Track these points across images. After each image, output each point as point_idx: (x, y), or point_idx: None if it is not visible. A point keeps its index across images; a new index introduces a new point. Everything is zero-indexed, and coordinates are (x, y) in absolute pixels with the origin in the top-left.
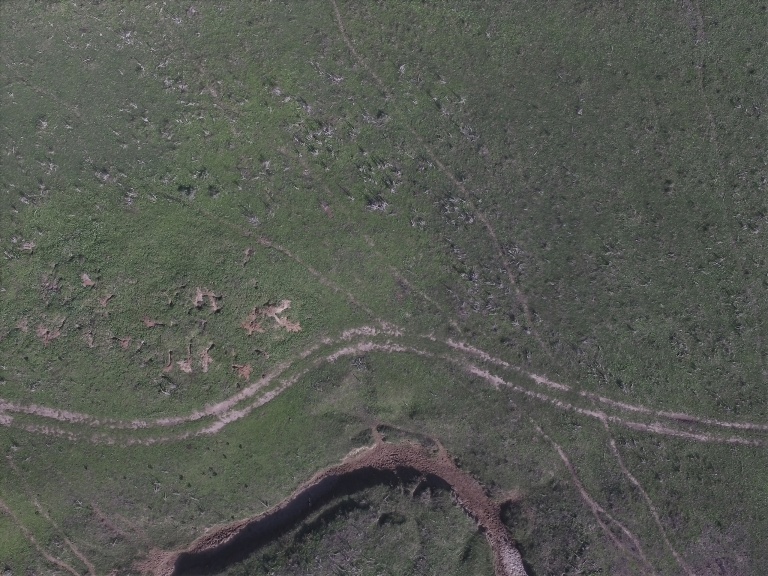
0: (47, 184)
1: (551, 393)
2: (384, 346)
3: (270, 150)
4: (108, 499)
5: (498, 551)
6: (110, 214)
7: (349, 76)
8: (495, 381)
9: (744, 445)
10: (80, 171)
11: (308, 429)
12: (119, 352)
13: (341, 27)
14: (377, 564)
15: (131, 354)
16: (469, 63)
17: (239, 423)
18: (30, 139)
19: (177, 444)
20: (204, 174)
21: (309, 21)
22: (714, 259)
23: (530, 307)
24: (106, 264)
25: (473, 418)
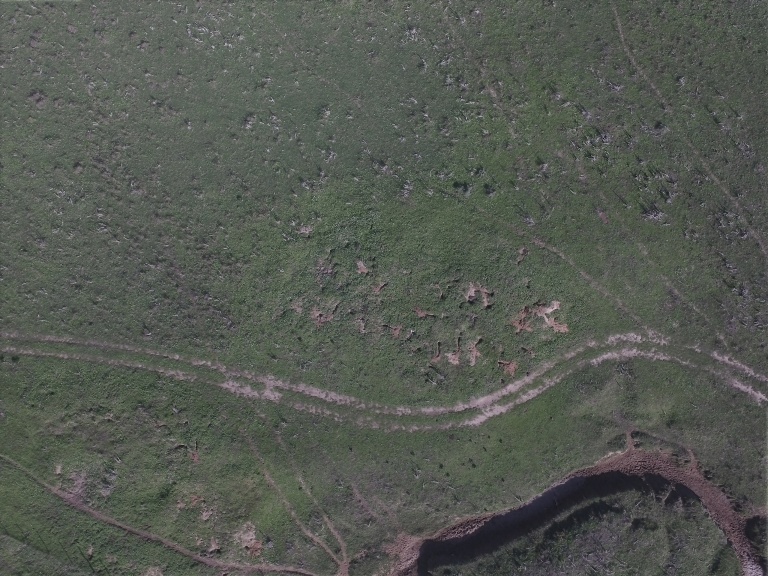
0: (326, 171)
1: None
2: (648, 354)
3: (547, 153)
4: (368, 481)
5: (740, 566)
6: (386, 204)
7: (628, 85)
8: (757, 397)
9: None
10: (358, 161)
11: (568, 429)
12: (390, 339)
13: (621, 36)
14: (629, 568)
15: (401, 342)
16: (748, 80)
17: (501, 418)
18: (312, 126)
19: (440, 433)
20: (481, 172)
21: (590, 28)
22: None
23: None
24: (381, 253)
25: (731, 432)
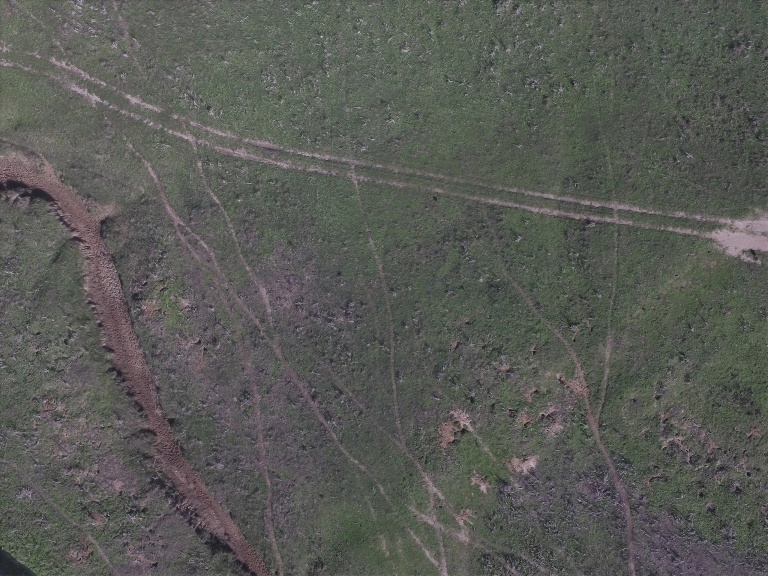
0: None
1: (144, 113)
2: None
3: None
4: None
5: (97, 265)
6: None
7: None
8: (93, 99)
9: (322, 175)
10: None
11: None
12: None
13: None
14: None
15: None
16: None
17: None
18: None
19: None
20: None
21: None
22: (309, 3)
23: (131, 33)
24: None
25: (72, 133)
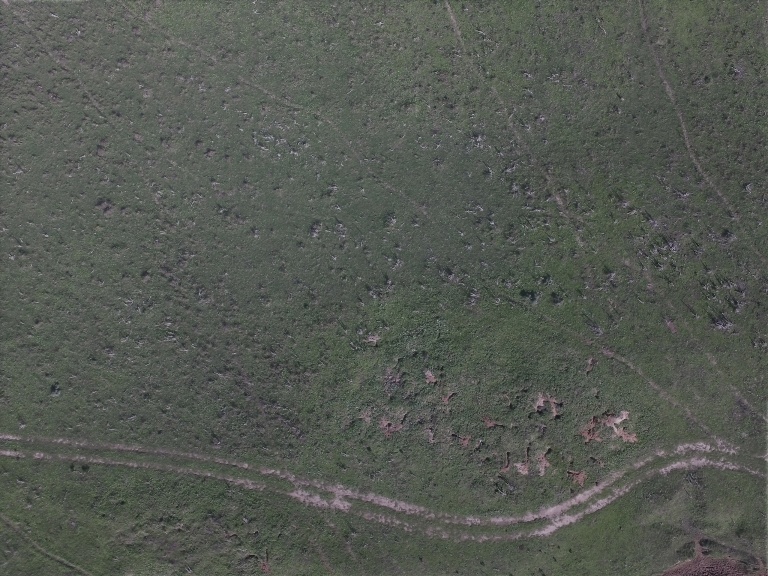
0: (392, 279)
1: None
2: (717, 463)
3: (614, 261)
4: None
5: None
6: (453, 313)
7: (694, 192)
8: None
9: None
10: (424, 268)
11: (637, 539)
12: (459, 450)
13: (687, 143)
14: None
15: (470, 452)
16: None
17: (571, 528)
18: (378, 234)
19: (510, 544)
20: (548, 281)
21: (655, 135)
22: None
23: None
24: (449, 362)
25: None
